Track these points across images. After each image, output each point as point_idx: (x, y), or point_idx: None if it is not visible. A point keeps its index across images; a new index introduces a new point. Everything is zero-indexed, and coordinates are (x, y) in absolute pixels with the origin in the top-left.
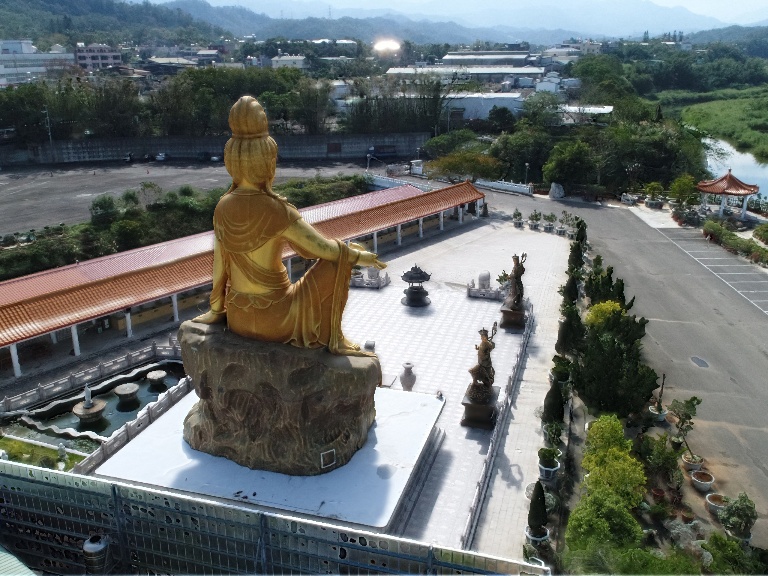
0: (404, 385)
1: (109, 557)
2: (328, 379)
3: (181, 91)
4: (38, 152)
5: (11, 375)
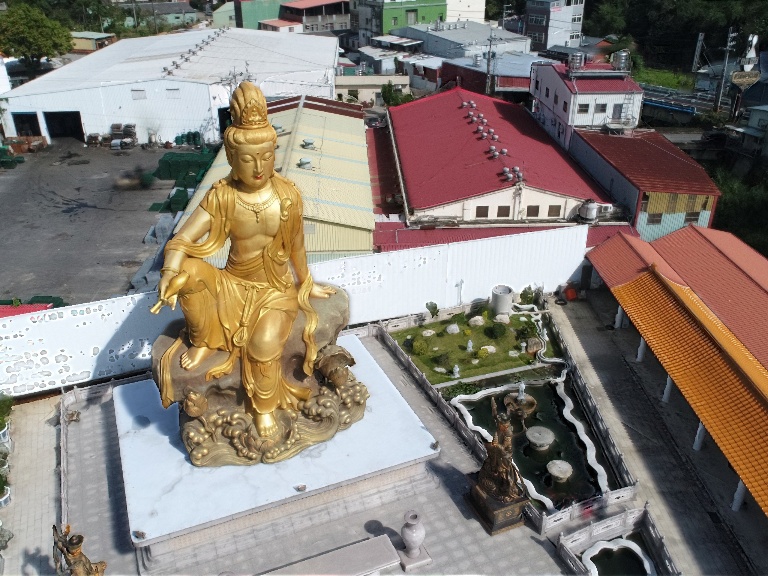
0: None
1: None
2: None
3: None
4: None
5: None
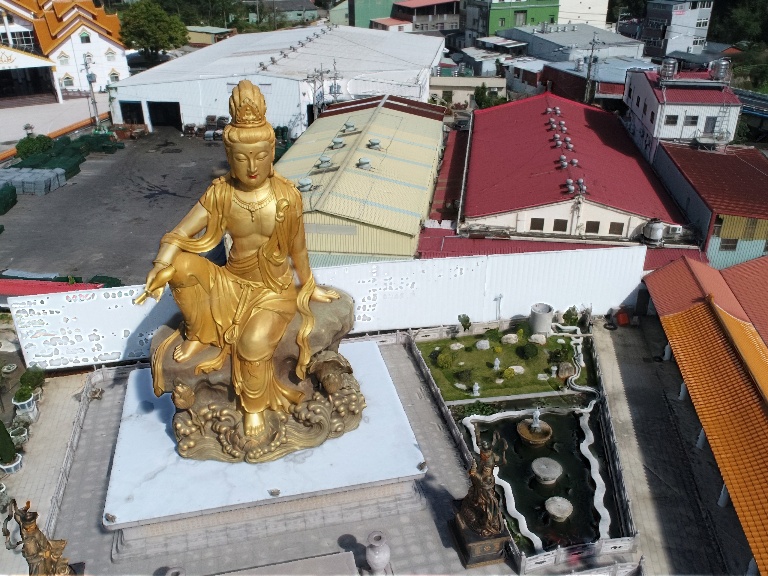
0: None
1: None
2: None
3: None
4: None
5: None
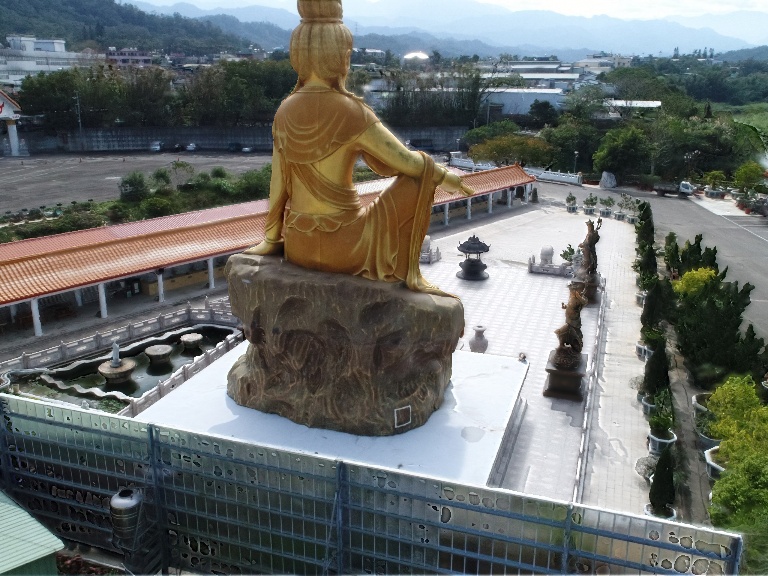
0: (474, 351)
1: (142, 517)
2: (408, 316)
3: (214, 81)
4: (67, 139)
5: (31, 334)
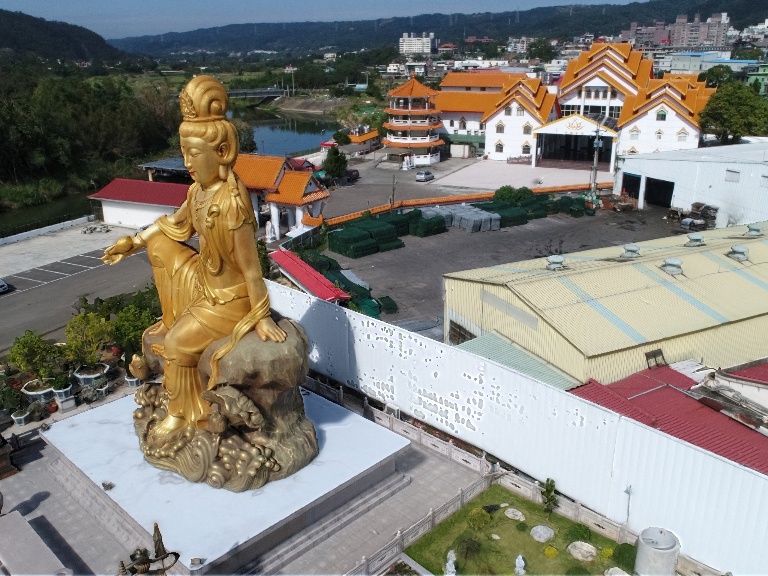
0: None
1: None
2: None
3: None
4: None
5: None
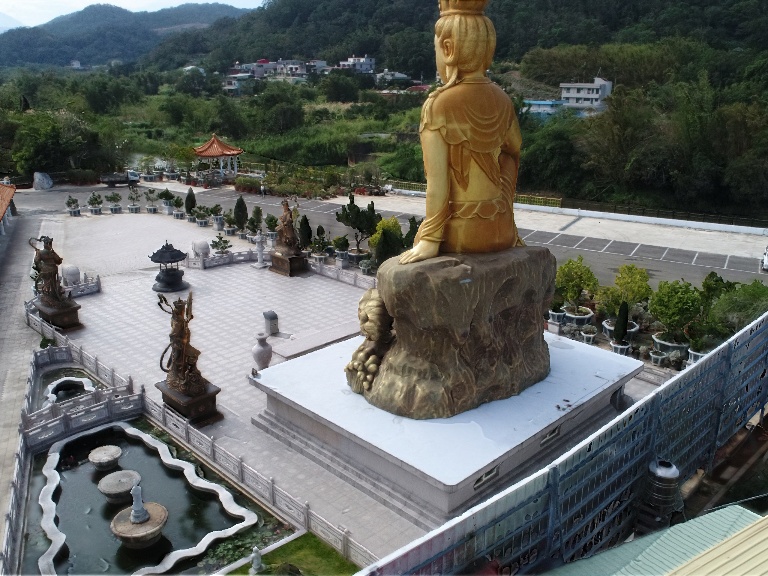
0: None
1: None
2: None
3: None
4: None
5: None
